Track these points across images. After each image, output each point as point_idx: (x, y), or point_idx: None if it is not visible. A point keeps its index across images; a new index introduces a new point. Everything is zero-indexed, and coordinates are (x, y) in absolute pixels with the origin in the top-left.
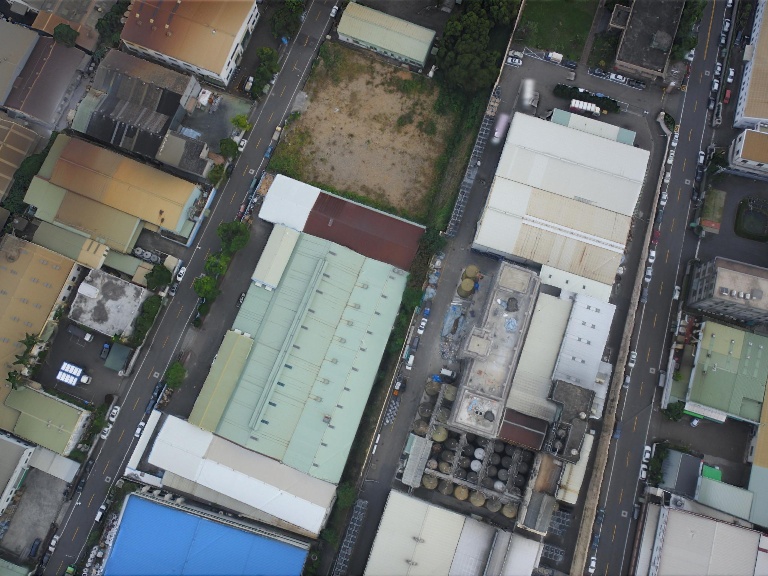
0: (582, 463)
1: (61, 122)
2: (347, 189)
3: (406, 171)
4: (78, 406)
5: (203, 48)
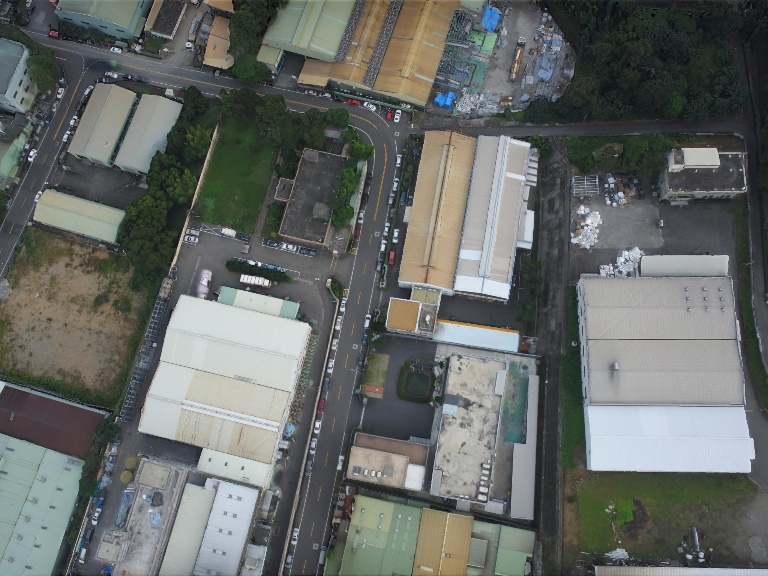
0: None
1: None
2: (44, 374)
3: (101, 351)
4: None
5: None
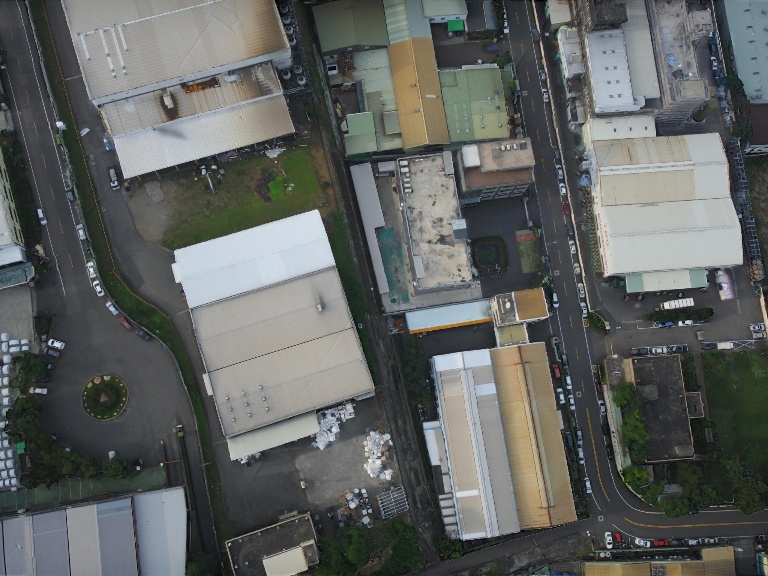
0: (552, 1)
1: None
2: None
3: None
4: None
5: None
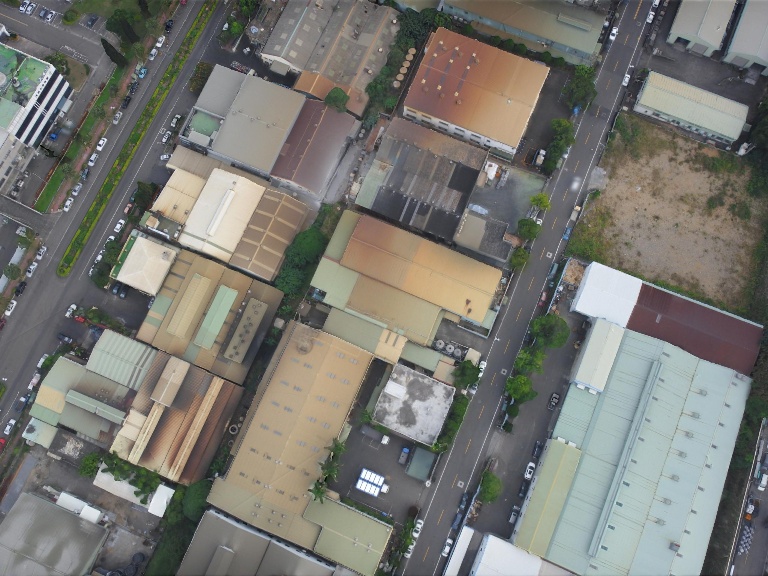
0: None
1: (329, 193)
2: (657, 277)
3: (721, 259)
4: (380, 520)
5: (496, 118)
